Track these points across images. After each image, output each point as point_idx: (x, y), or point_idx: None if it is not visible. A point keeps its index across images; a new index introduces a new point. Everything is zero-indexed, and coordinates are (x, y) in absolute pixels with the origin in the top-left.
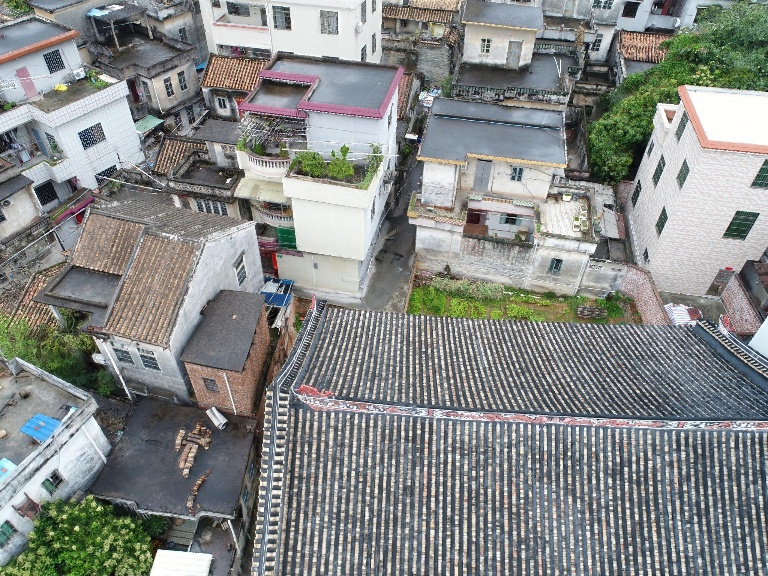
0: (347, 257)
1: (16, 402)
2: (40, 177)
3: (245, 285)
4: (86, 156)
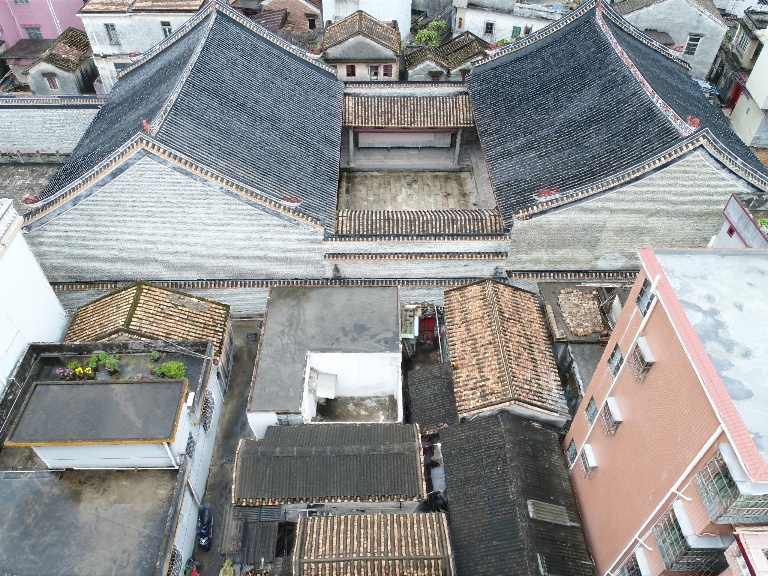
0: (757, 102)
1: (567, 8)
2: (722, 4)
3: (689, 59)
4: (755, 8)
